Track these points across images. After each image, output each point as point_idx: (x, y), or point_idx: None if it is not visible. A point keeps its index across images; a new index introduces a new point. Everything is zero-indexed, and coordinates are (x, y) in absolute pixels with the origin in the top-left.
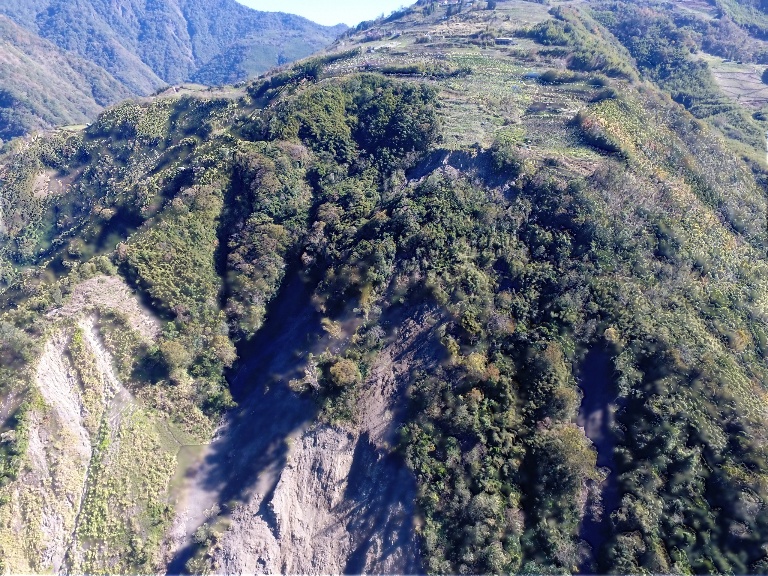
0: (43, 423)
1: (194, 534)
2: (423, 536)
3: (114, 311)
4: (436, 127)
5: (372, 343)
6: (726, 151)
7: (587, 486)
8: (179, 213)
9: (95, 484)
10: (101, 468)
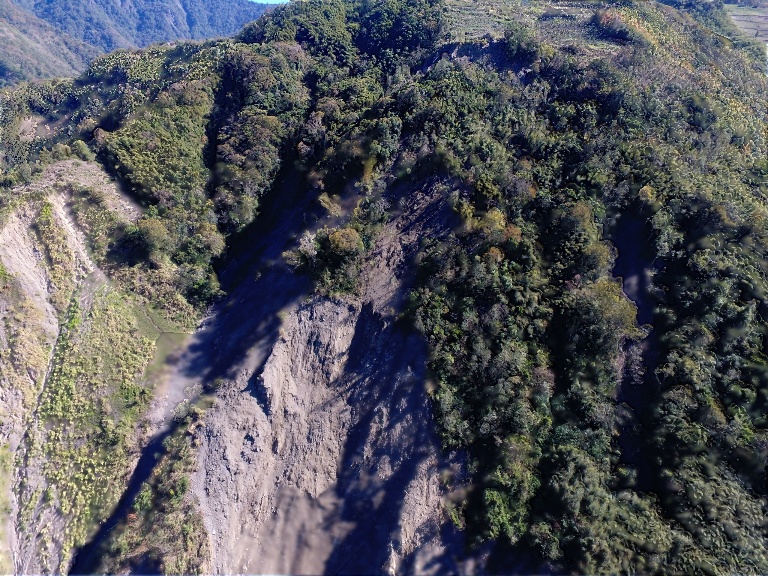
0: (3, 292)
1: (172, 410)
2: (436, 400)
3: (89, 188)
4: (444, 24)
5: (376, 216)
6: (751, 66)
7: (624, 351)
8: (165, 107)
9: (61, 362)
10: (69, 346)
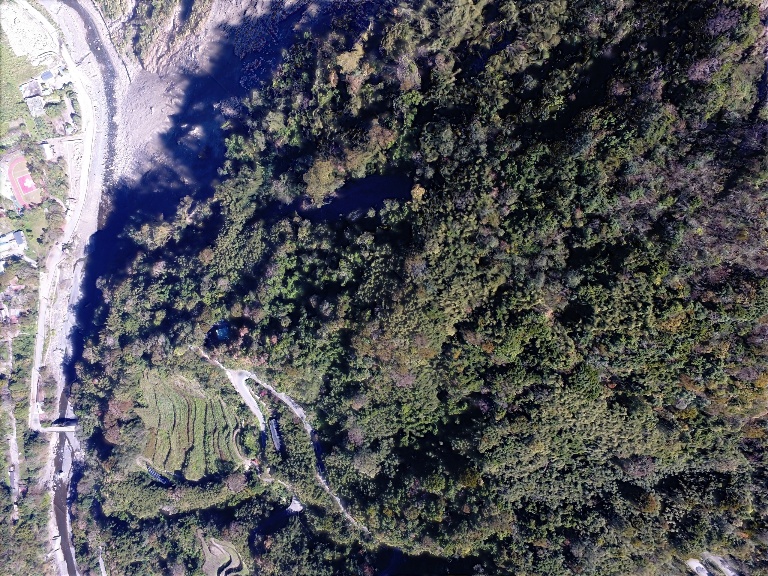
0: None
1: None
2: None
3: None
4: None
5: None
6: None
7: None
8: None
9: None
10: None
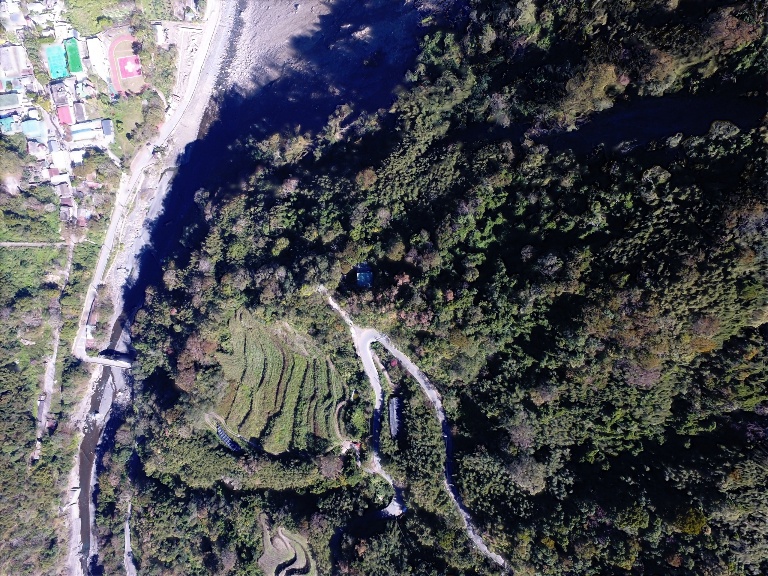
0: None
1: None
2: None
3: None
4: None
5: None
6: None
7: None
8: None
9: None
10: None
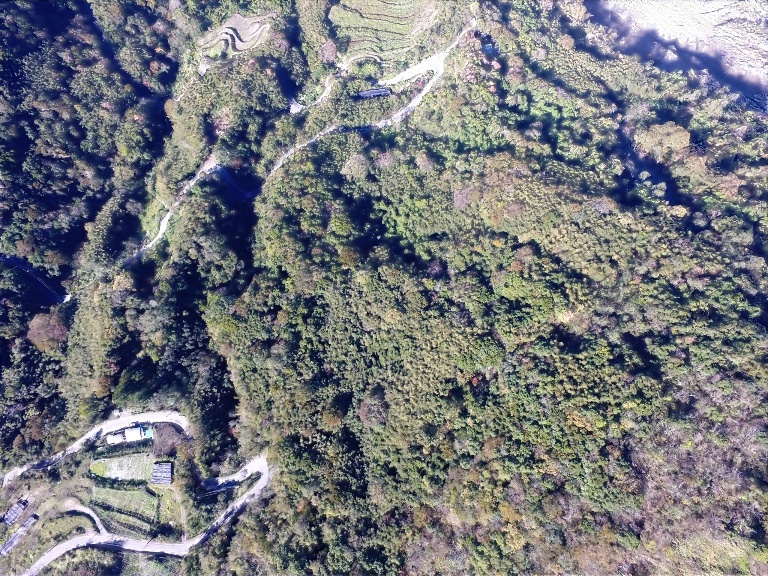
0: None
1: None
2: None
3: None
4: None
5: None
6: None
7: None
8: None
9: None
10: None
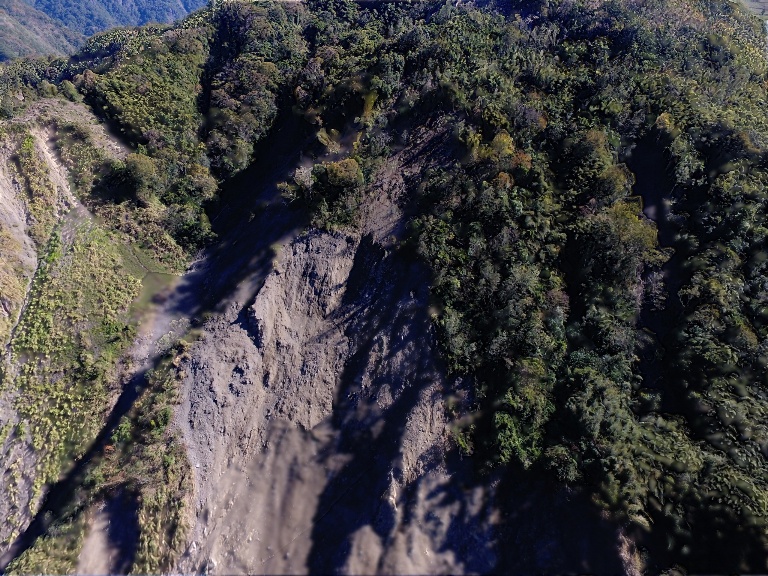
0: None
1: (156, 342)
2: (441, 325)
3: (74, 123)
4: None
5: (377, 149)
6: (762, 31)
7: (642, 280)
8: None
9: (39, 296)
10: (48, 279)
